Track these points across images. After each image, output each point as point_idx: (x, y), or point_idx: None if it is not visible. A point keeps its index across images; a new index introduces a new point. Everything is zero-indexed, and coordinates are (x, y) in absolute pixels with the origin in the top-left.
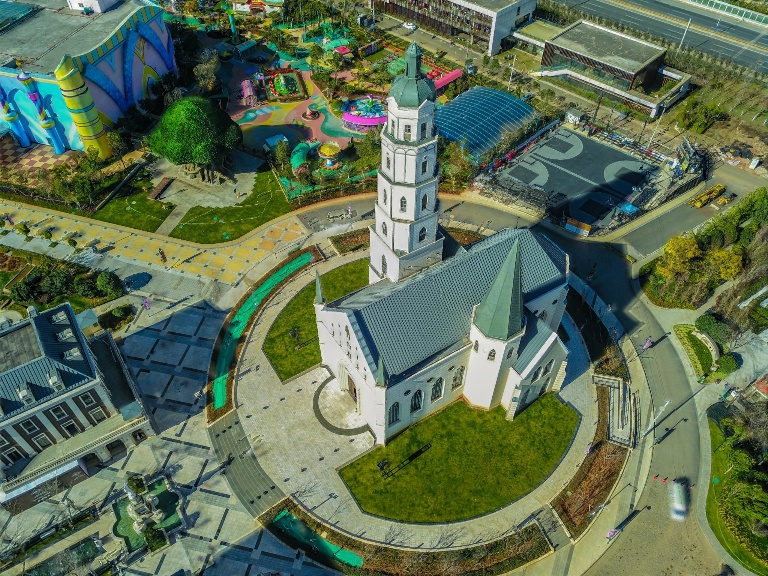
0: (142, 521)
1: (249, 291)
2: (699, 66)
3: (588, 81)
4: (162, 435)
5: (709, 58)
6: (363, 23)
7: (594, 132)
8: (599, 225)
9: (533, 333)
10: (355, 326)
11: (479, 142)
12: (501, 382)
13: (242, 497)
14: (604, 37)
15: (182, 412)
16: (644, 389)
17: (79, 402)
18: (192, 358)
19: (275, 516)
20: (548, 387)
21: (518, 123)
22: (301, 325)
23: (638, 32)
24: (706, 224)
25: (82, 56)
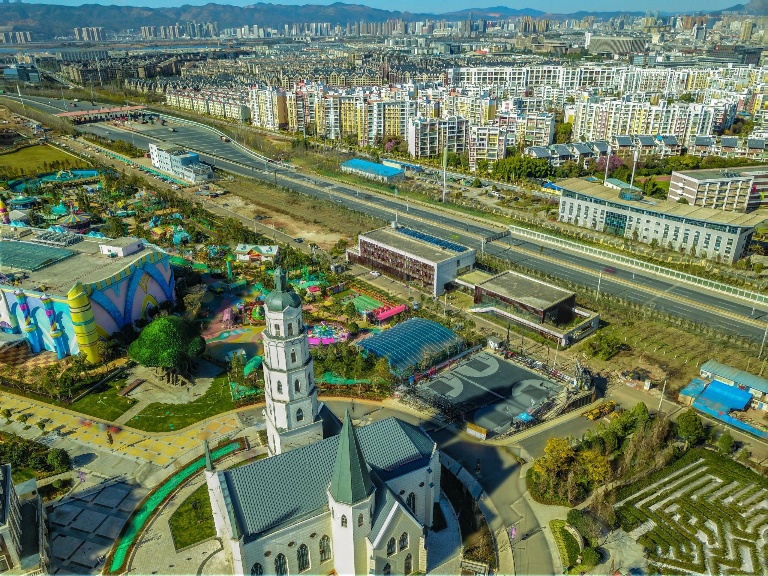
0: None
1: (175, 472)
2: (615, 308)
3: (509, 316)
4: None
5: (625, 303)
6: (337, 270)
7: (510, 356)
8: (494, 429)
9: (383, 503)
10: (223, 484)
11: (404, 359)
12: (360, 553)
13: None
14: (525, 283)
15: (81, 573)
16: None
17: None
18: (107, 527)
19: None
20: (413, 567)
21: (442, 346)
22: (209, 502)
23: (566, 282)
24: (586, 431)
25: (92, 284)
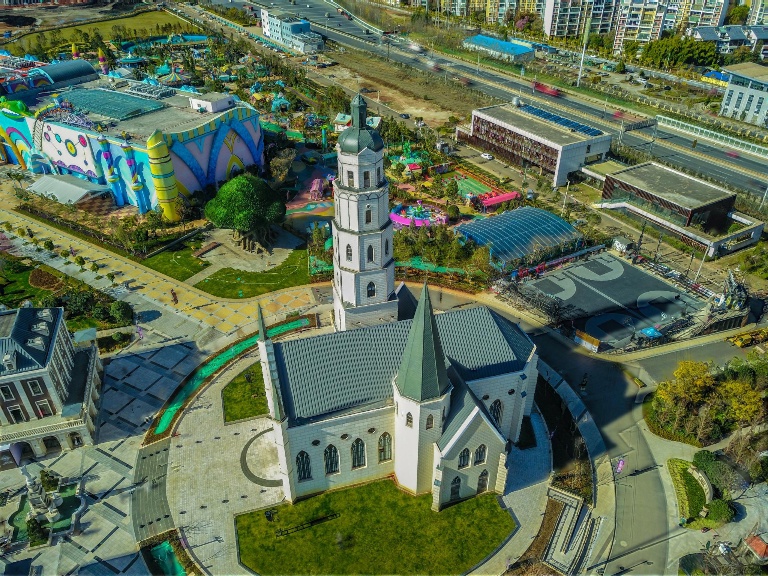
0: (36, 515)
1: (237, 341)
2: None
3: (645, 215)
4: (98, 446)
5: None
6: (444, 150)
7: (640, 261)
8: (610, 342)
9: (460, 407)
10: (271, 357)
11: (508, 250)
12: (426, 460)
13: (136, 519)
14: (670, 177)
15: (126, 430)
16: (608, 517)
17: (27, 388)
18: (159, 387)
19: (155, 544)
20: (488, 485)
21: (556, 240)
22: None
23: (722, 184)
24: None
25: (173, 134)
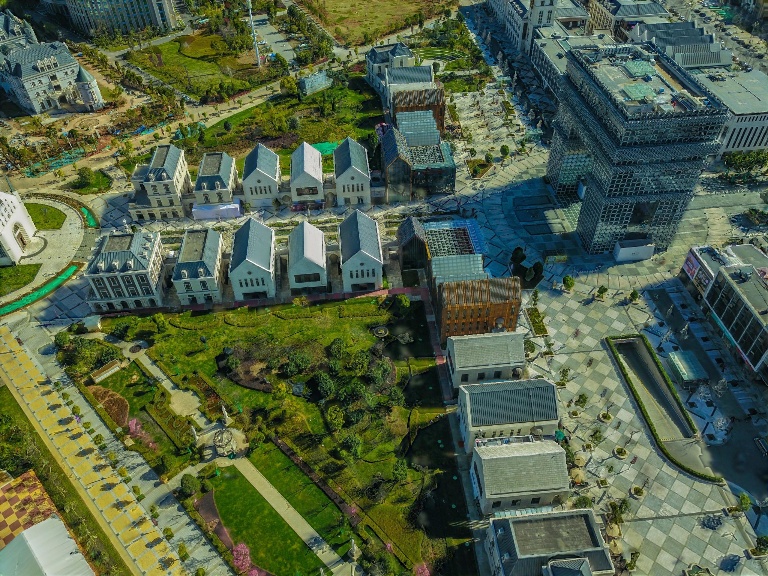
0: None
1: (4, 316)
2: None
3: None
4: None
5: None
6: None
7: None
8: None
9: None
10: None
11: None
12: None
13: None
14: None
15: None
16: None
17: None
18: (65, 294)
19: None
20: None
21: None
22: (5, 285)
23: None
24: None
25: None
